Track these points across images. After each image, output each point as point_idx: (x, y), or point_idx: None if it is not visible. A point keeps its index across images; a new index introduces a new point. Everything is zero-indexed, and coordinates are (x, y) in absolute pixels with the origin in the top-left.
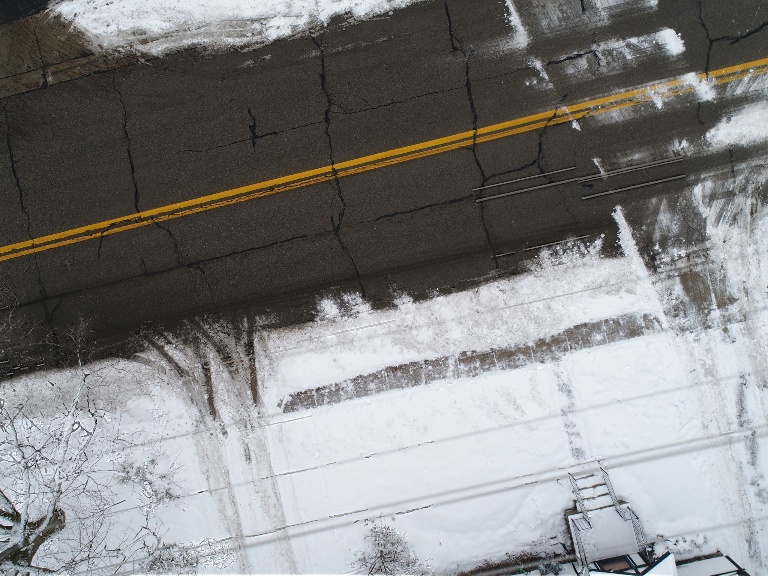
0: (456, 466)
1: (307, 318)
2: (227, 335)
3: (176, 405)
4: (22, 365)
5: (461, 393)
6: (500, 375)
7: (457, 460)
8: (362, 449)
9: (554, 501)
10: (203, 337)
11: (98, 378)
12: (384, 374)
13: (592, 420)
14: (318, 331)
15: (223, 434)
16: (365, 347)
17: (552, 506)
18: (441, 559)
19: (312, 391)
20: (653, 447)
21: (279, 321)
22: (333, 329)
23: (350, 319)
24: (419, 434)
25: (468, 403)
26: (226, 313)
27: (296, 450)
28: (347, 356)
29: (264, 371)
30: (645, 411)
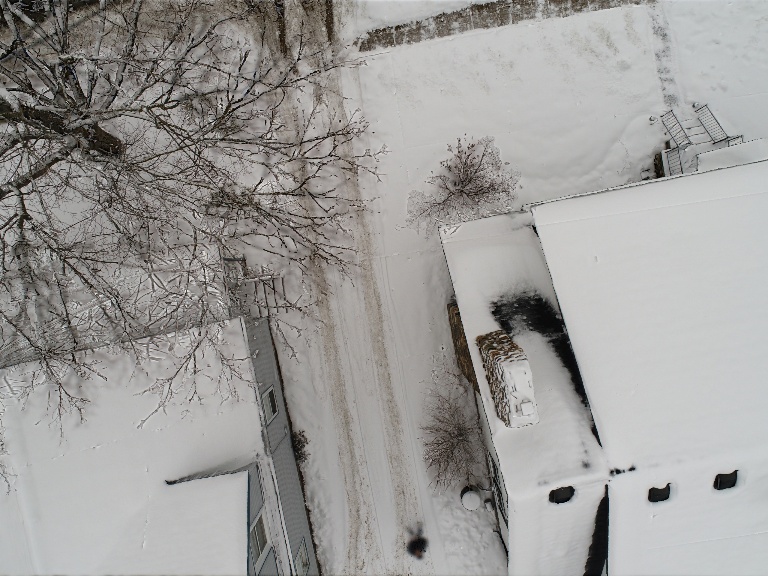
0: (542, 106)
1: None
2: None
3: None
4: None
5: (551, 29)
6: (593, 12)
7: (543, 100)
8: (442, 86)
9: (645, 143)
10: None
11: None
12: (469, 12)
13: (688, 62)
14: None
15: (294, 73)
16: None
17: (642, 149)
18: (521, 201)
19: (391, 29)
20: (752, 92)
21: None
22: None
23: None
24: (504, 71)
25: (558, 39)
26: None
27: (372, 83)
28: None
29: (341, 6)
30: (745, 53)
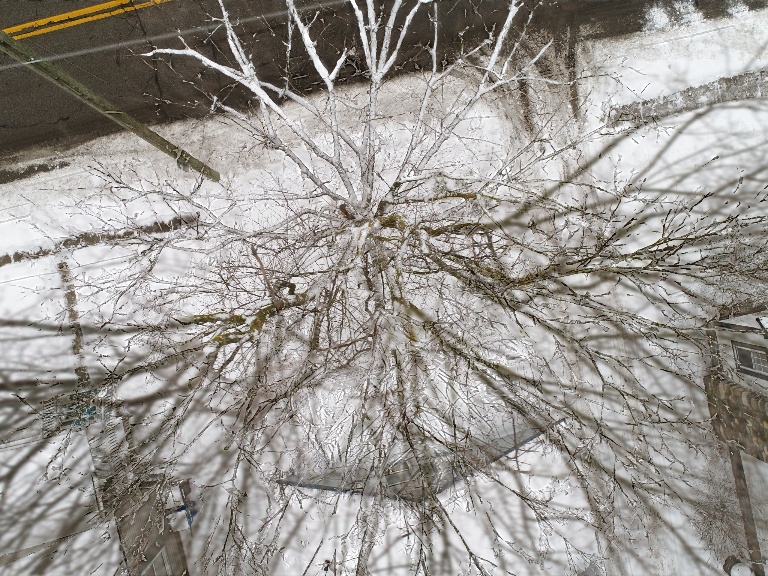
0: None
1: (634, 28)
2: None
3: (490, 120)
4: (322, 80)
5: None
6: None
7: None
8: (696, 161)
9: None
10: (521, 48)
11: (407, 91)
12: (717, 86)
13: None
14: (649, 39)
15: (540, 150)
16: (702, 53)
17: None
18: None
19: (638, 104)
20: None
21: (604, 31)
22: (666, 36)
23: (682, 27)
24: (759, 144)
25: None
26: (547, 22)
27: (626, 161)
28: (683, 62)
29: (587, 83)
30: None
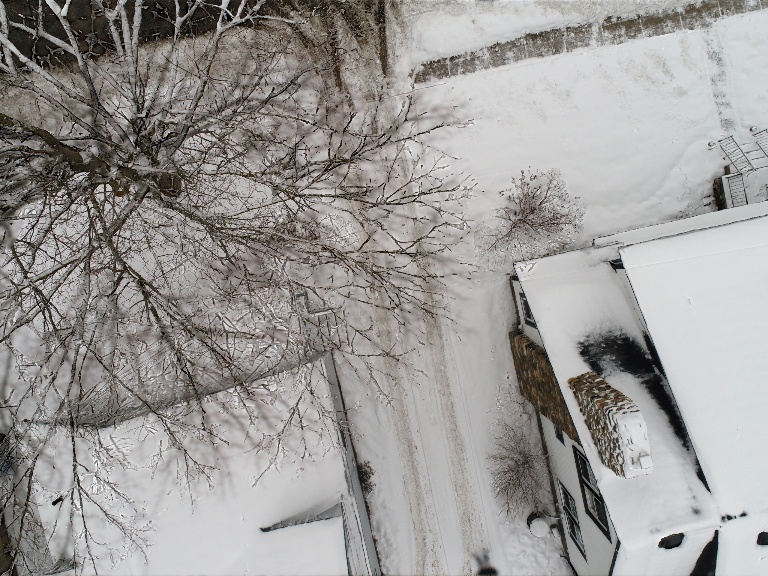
0: (599, 134)
1: None
2: (357, 1)
3: None
4: None
5: (607, 56)
6: (648, 39)
7: (600, 128)
8: (499, 116)
9: (703, 168)
10: (331, 4)
11: None
12: (523, 42)
13: (744, 87)
14: None
15: (349, 106)
16: (506, 8)
17: (701, 174)
18: None
19: (446, 60)
20: None
21: None
22: None
23: None
24: (561, 100)
25: (614, 67)
26: None
27: (430, 115)
28: (487, 17)
29: (395, 39)
30: None
